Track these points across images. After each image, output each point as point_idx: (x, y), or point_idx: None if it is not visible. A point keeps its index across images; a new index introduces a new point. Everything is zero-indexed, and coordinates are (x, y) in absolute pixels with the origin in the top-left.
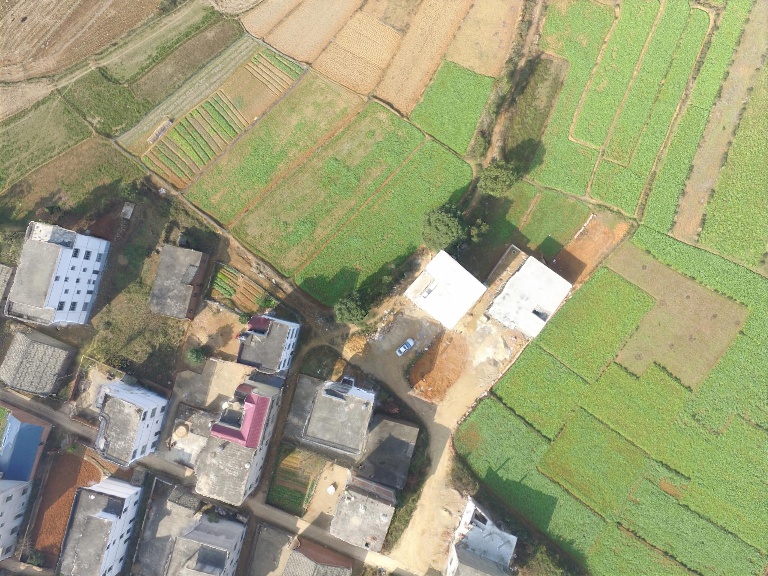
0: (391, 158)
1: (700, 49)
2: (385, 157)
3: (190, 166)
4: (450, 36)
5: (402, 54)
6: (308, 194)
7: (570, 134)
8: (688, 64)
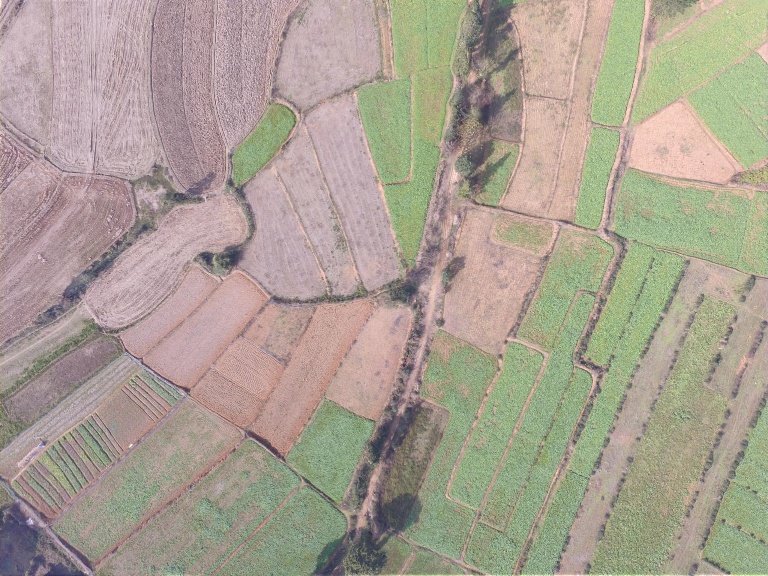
0: (265, 503)
1: (582, 411)
2: (259, 502)
3: (61, 494)
4: (331, 372)
5: (282, 388)
6: (178, 537)
7: (447, 492)
8: (569, 427)
